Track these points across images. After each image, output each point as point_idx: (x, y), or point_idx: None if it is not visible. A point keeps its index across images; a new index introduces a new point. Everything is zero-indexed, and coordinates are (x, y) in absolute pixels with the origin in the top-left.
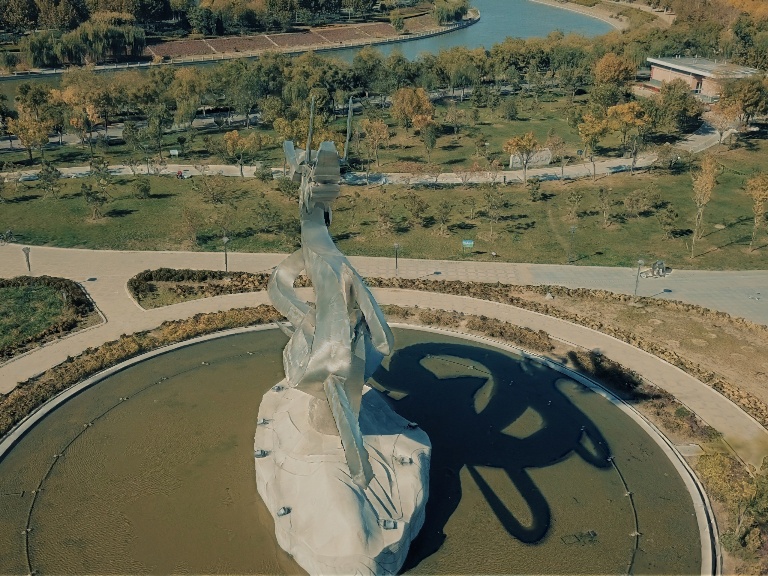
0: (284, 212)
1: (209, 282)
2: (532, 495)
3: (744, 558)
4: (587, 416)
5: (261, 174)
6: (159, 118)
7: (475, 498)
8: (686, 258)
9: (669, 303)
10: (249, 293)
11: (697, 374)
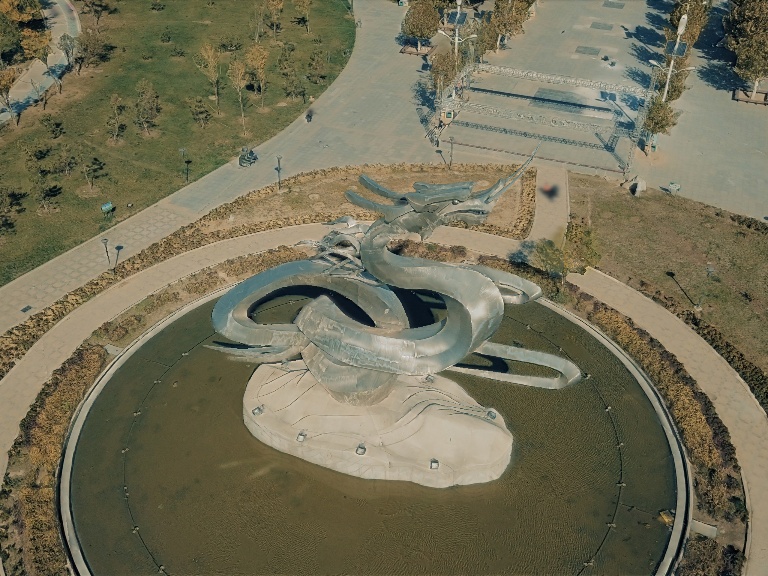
0: None
1: None
2: None
3: (571, 302)
4: None
5: None
6: None
7: (450, 373)
8: (243, 136)
9: (297, 178)
10: (10, 373)
11: None
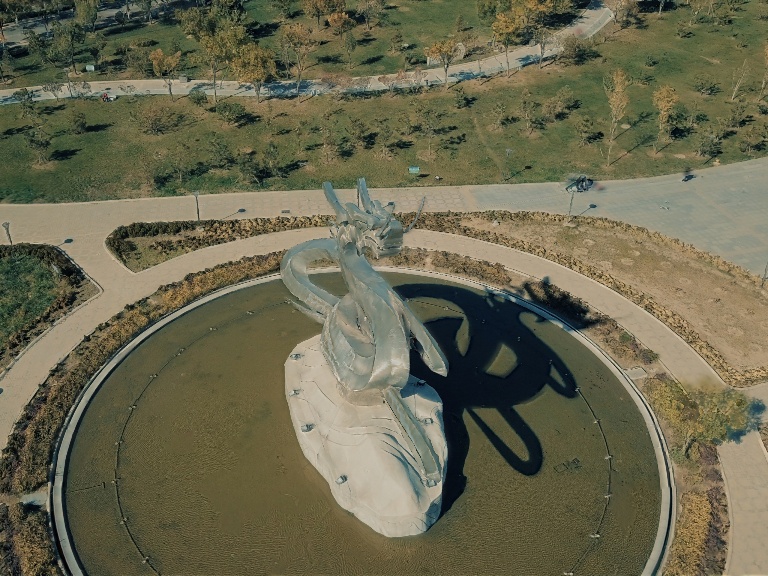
0: (228, 141)
1: (184, 234)
2: (524, 431)
3: (689, 468)
4: (551, 349)
5: (196, 98)
6: (71, 34)
7: (481, 440)
8: (603, 167)
9: (597, 221)
10: (226, 244)
11: (631, 297)
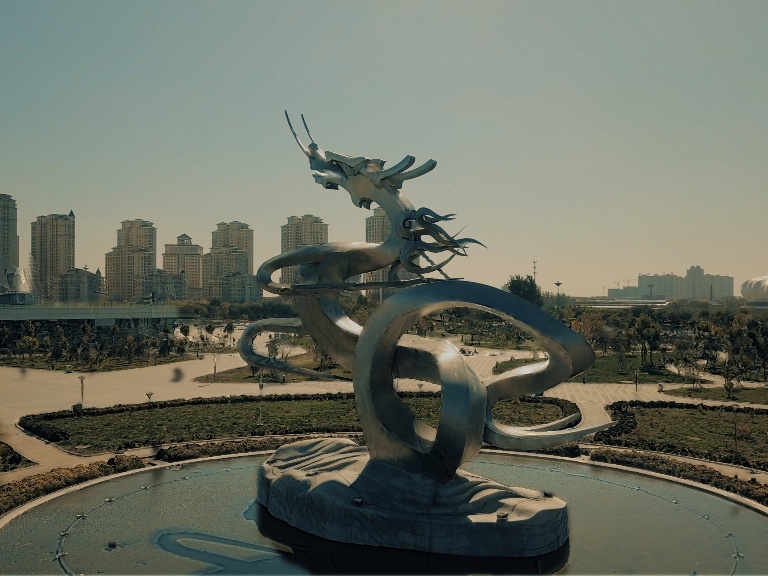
0: None
1: None
2: (195, 553)
3: None
4: None
5: None
6: None
7: (251, 539)
8: None
9: None
10: None
11: None
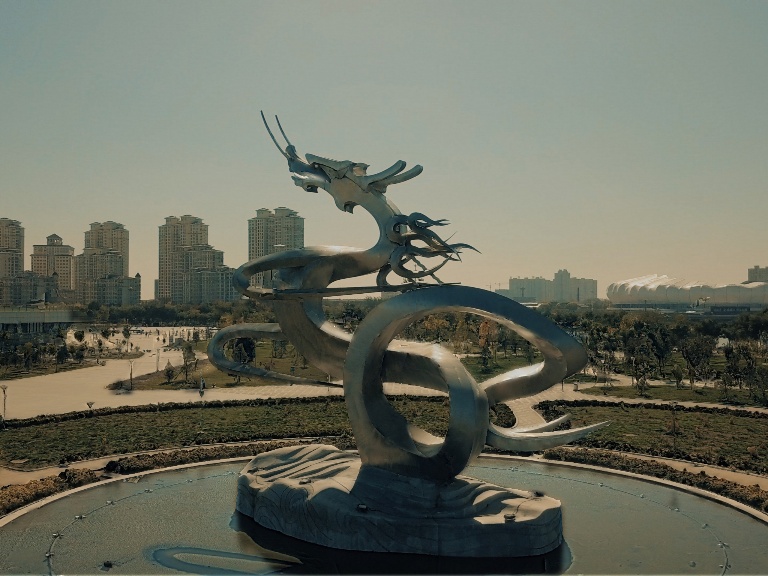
0: None
1: None
2: (201, 569)
3: None
4: None
5: None
6: None
7: (251, 551)
8: None
9: None
10: None
11: None
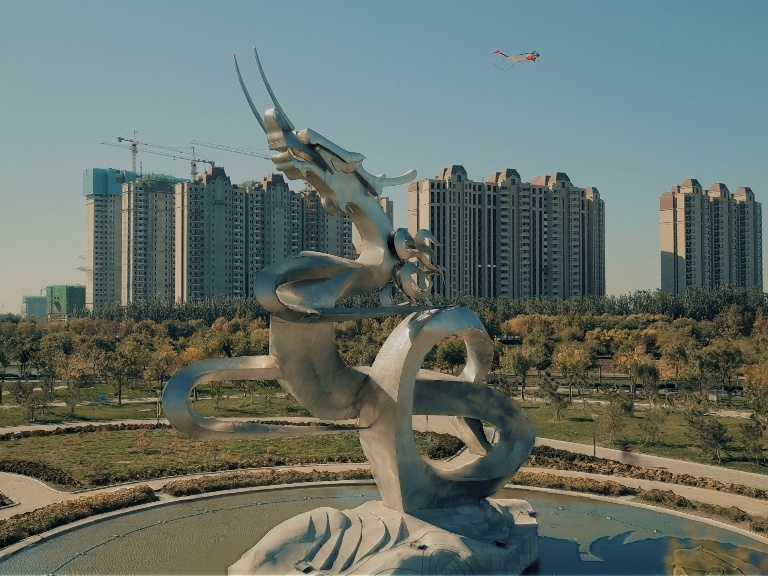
0: None
1: (574, 462)
2: None
3: None
4: None
5: (756, 405)
6: (699, 359)
7: None
8: None
9: None
10: (596, 474)
11: None
